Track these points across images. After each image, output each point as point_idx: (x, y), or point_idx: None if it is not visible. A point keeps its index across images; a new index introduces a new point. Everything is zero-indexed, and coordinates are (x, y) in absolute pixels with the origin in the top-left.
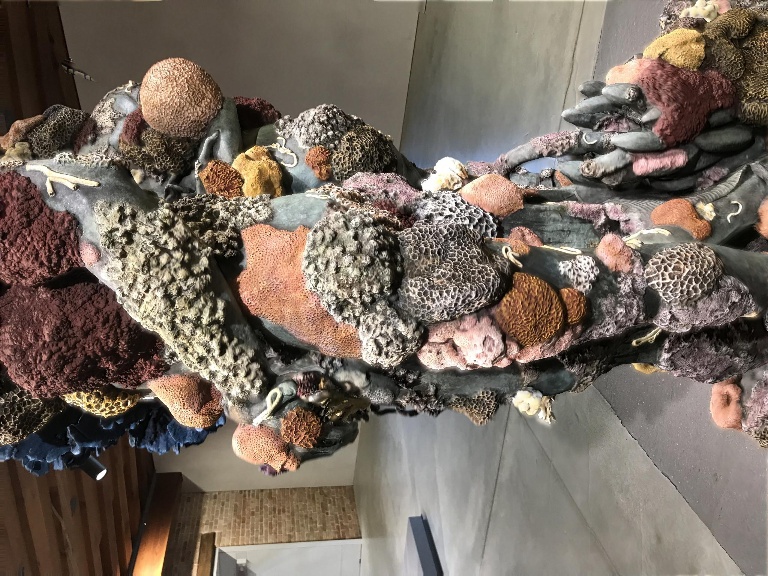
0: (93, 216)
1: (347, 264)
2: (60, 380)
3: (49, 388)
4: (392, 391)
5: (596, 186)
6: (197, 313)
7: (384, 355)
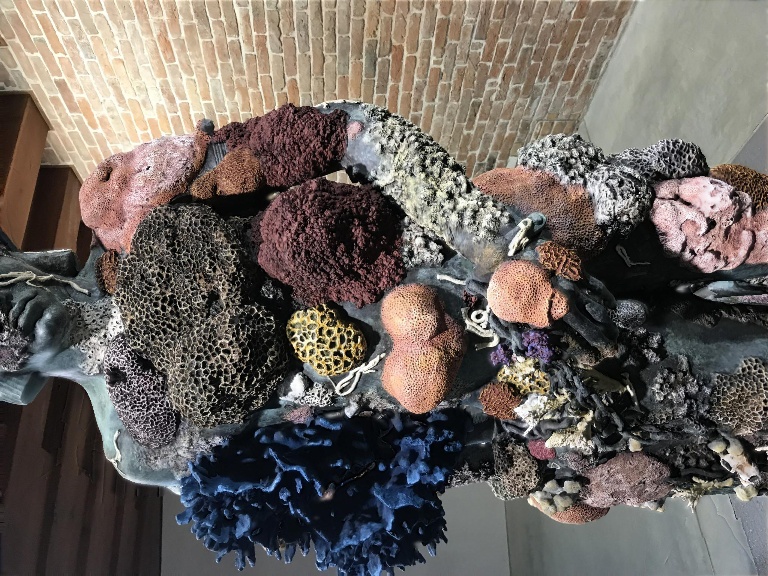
0: (358, 109)
1: (560, 137)
2: (320, 220)
3: (307, 236)
4: (640, 303)
5: (754, 294)
6: (444, 154)
7: (620, 196)
